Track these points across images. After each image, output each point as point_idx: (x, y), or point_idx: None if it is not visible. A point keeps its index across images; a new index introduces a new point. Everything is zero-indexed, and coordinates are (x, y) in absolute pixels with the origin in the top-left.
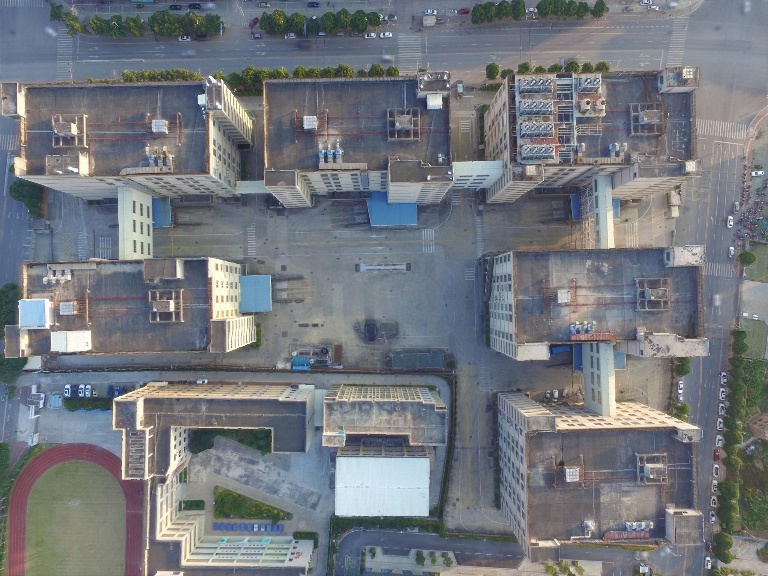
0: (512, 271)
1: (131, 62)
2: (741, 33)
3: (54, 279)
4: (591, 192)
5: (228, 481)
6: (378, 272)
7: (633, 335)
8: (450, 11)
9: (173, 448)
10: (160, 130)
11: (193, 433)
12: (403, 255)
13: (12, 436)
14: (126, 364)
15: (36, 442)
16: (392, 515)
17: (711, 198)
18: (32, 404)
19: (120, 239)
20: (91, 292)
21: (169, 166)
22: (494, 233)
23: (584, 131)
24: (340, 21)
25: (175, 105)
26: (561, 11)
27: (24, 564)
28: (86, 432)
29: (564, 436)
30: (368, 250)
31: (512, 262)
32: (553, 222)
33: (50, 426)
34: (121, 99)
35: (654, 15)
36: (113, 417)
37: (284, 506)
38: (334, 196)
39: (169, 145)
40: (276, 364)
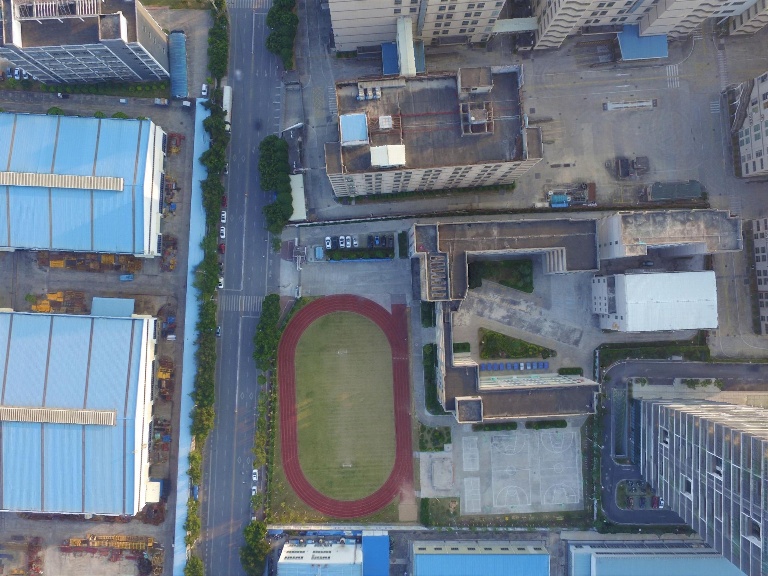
0: None
1: None
2: None
3: (371, 94)
4: None
5: (491, 323)
6: (625, 110)
7: None
8: None
9: None
10: None
11: None
12: (649, 92)
13: (275, 291)
14: (384, 213)
15: (300, 295)
16: (682, 328)
17: None
18: (299, 255)
19: (404, 69)
20: (401, 109)
21: None
22: (736, 66)
23: None
24: None
25: None
26: None
27: (296, 416)
28: (348, 283)
29: None
30: (614, 89)
31: None
32: None
33: (312, 279)
34: None
35: None
36: (415, 241)
37: (547, 344)
38: (588, 30)
39: None
40: (534, 203)
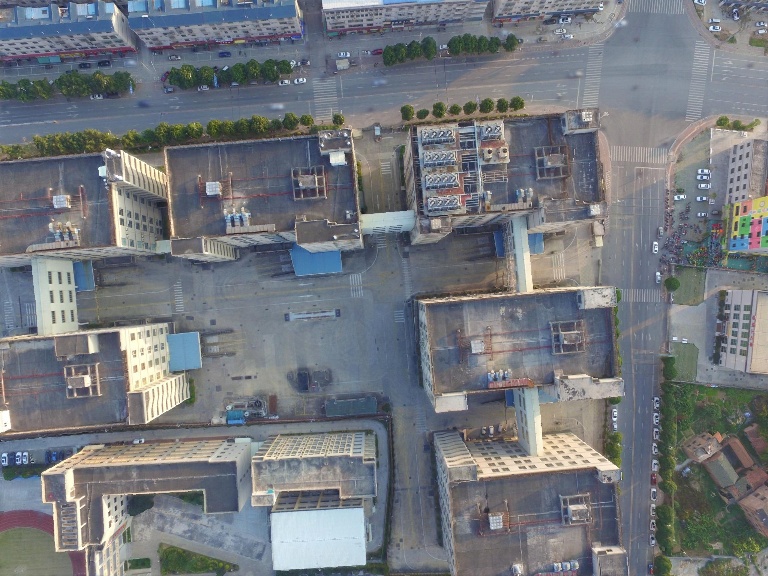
0: (426, 323)
1: (44, 124)
2: (657, 56)
3: None
4: (510, 231)
5: (172, 537)
6: (308, 320)
7: (551, 378)
8: (363, 53)
9: (107, 516)
10: (62, 206)
11: (132, 494)
12: (332, 302)
13: None
14: None
15: None
16: (330, 566)
17: (635, 225)
18: None
19: (37, 312)
20: (6, 372)
21: (75, 240)
22: (421, 274)
23: (490, 179)
24: (249, 72)
25: (77, 178)
26: (472, 48)
27: None
28: (27, 499)
29: (488, 483)
30: (296, 299)
31: (426, 314)
32: (479, 259)
33: None
34: (22, 175)
35: (569, 44)
36: (42, 491)
37: (230, 558)
38: (256, 249)
39: (74, 219)
40: (211, 419)
